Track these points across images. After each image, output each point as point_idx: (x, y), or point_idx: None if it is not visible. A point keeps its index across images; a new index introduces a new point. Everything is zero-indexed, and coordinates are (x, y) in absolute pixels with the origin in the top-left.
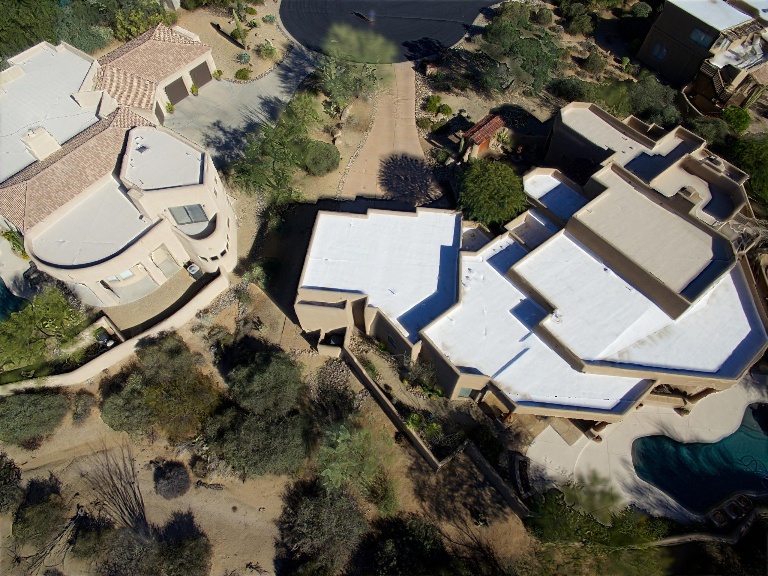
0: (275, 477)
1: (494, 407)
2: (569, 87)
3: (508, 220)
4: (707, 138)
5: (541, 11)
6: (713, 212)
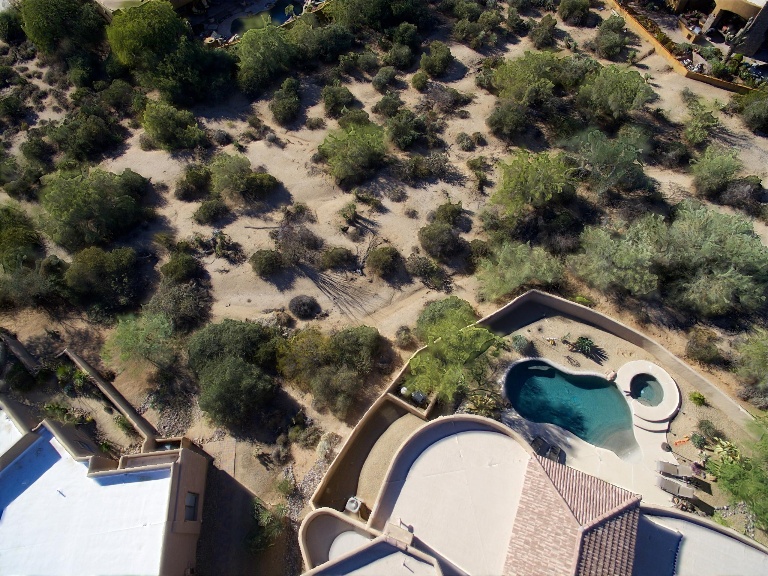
0: None
1: None
2: None
3: None
4: None
5: None
6: None
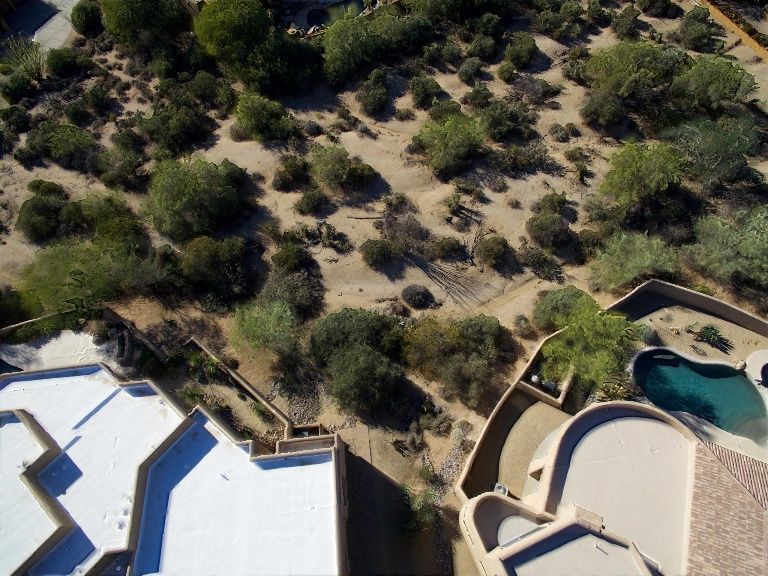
0: None
1: None
2: None
3: None
4: None
5: None
6: None
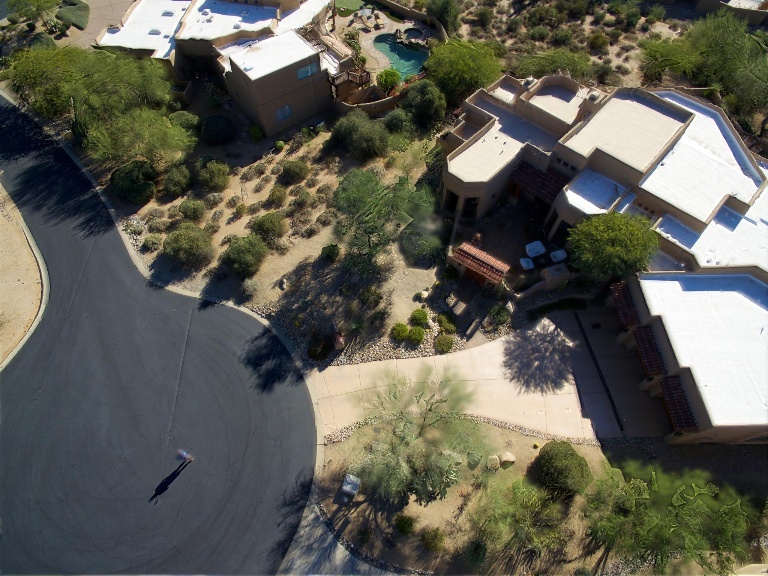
0: None
1: None
2: (363, 189)
3: None
4: (441, 96)
5: (190, 210)
6: (568, 98)
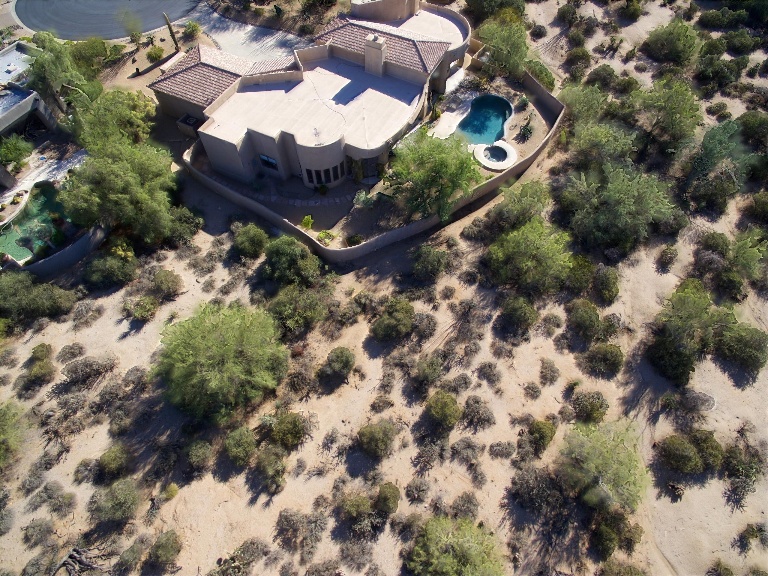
0: None
1: None
2: None
3: None
4: None
5: None
6: None
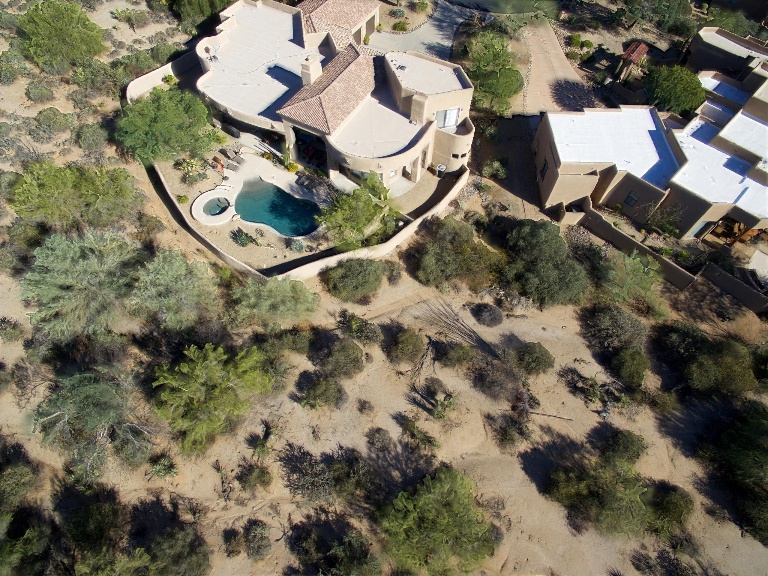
0: (563, 307)
1: (714, 242)
2: (678, 24)
3: (696, 108)
4: None
5: None
6: None
